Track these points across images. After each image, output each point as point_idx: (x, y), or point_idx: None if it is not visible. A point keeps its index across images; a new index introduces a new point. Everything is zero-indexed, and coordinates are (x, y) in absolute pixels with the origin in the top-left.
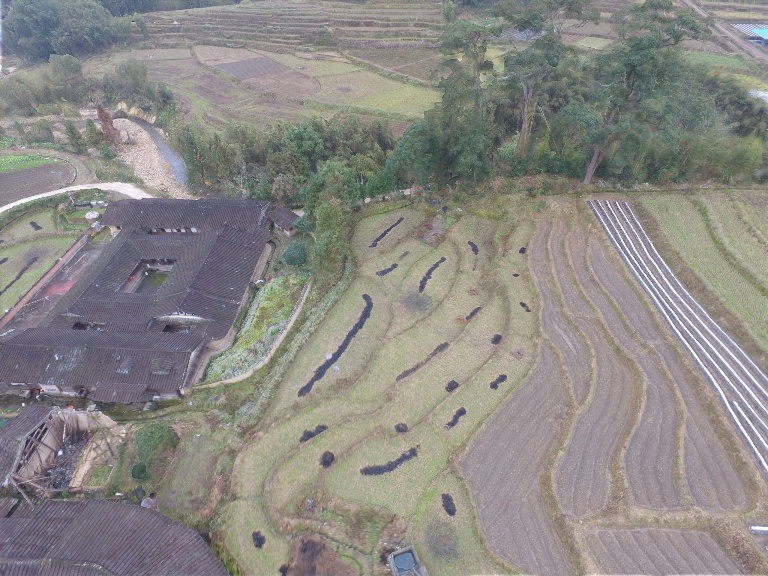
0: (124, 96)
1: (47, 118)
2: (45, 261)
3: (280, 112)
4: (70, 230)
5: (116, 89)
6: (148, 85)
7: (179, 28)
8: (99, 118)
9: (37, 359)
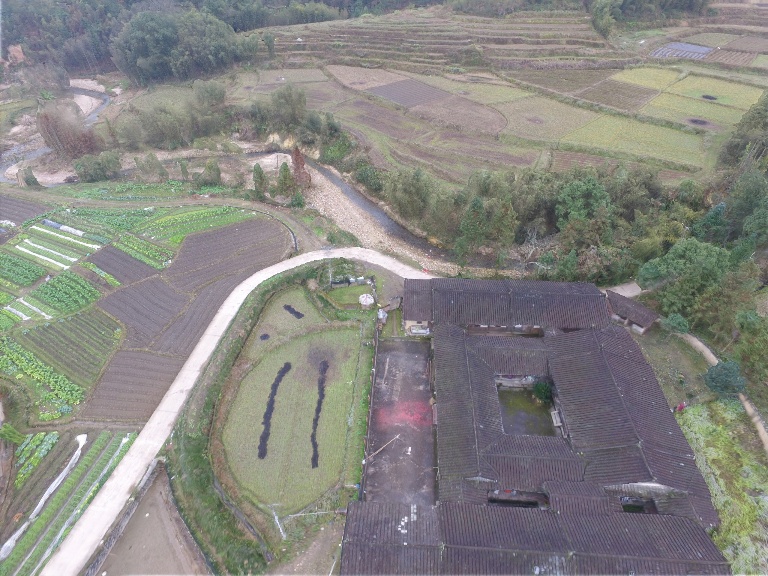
0: (278, 127)
1: (193, 152)
2: (340, 367)
3: (479, 149)
4: (343, 319)
5: (270, 119)
6: (310, 115)
7: (304, 46)
8: (293, 161)
9: (506, 573)
